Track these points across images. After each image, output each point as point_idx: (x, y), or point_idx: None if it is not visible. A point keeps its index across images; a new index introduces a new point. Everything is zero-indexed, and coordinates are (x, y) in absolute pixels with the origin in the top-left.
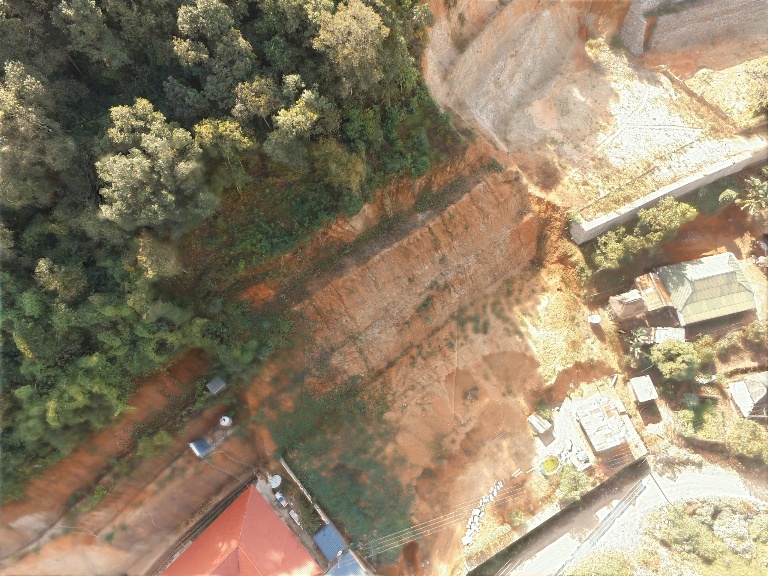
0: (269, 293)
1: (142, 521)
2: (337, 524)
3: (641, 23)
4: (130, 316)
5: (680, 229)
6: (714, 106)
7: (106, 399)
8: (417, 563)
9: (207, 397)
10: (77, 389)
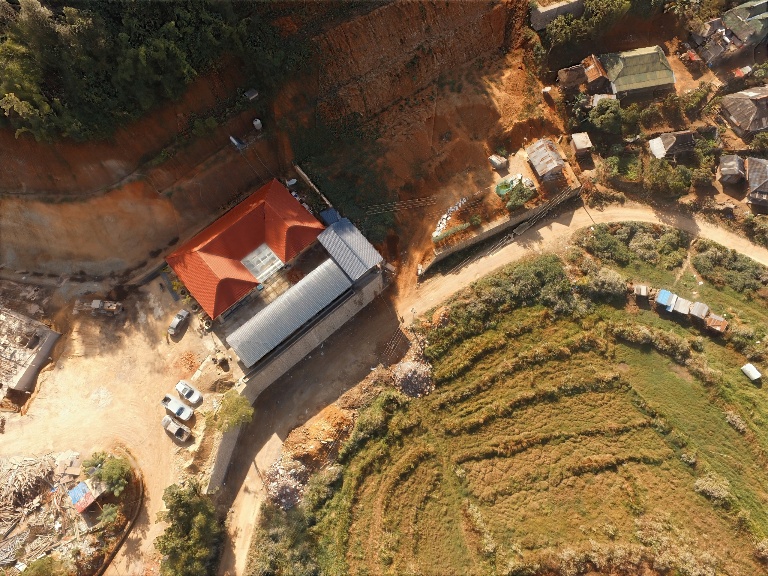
0: (294, 27)
1: (193, 189)
2: (338, 211)
3: None
4: (196, 3)
5: (621, 32)
6: None
7: (177, 62)
8: (397, 252)
9: (245, 100)
10: (160, 41)
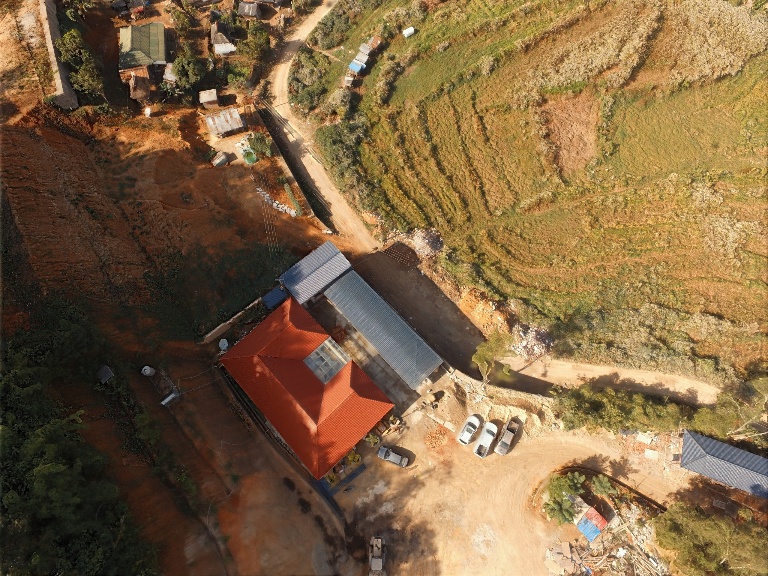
0: (19, 316)
1: (228, 451)
2: None
3: None
4: None
5: None
6: None
7: (61, 435)
8: (308, 250)
9: None
10: None
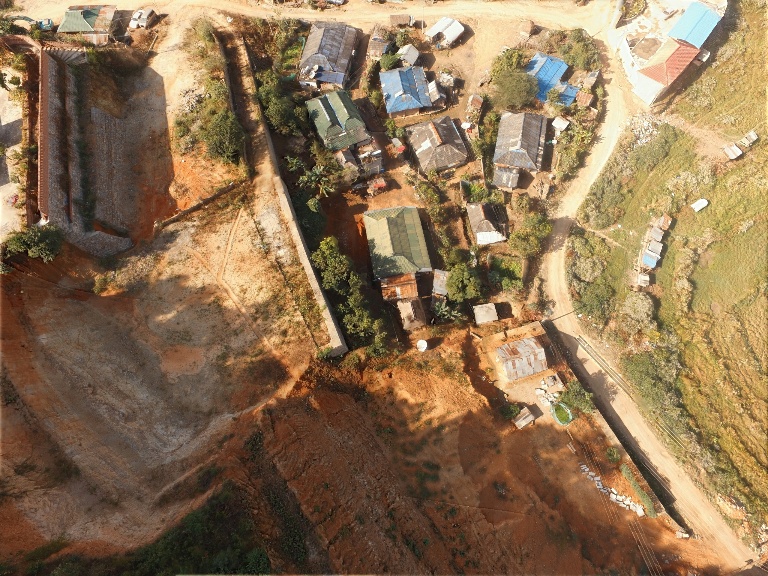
0: None
1: None
2: None
3: (96, 236)
4: None
5: None
6: (218, 193)
7: None
8: (666, 568)
9: None
10: None
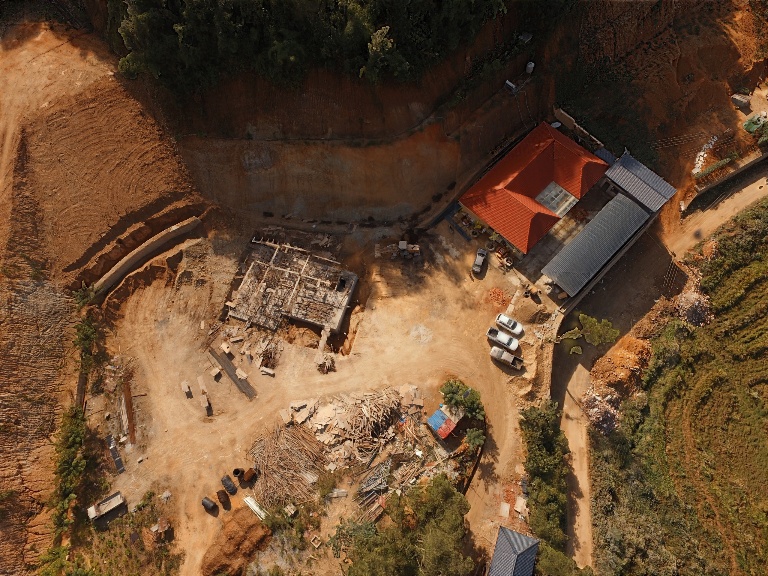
0: None
1: (476, 132)
2: None
3: None
4: None
5: None
6: None
7: (490, 1)
8: None
9: (522, 43)
10: None
